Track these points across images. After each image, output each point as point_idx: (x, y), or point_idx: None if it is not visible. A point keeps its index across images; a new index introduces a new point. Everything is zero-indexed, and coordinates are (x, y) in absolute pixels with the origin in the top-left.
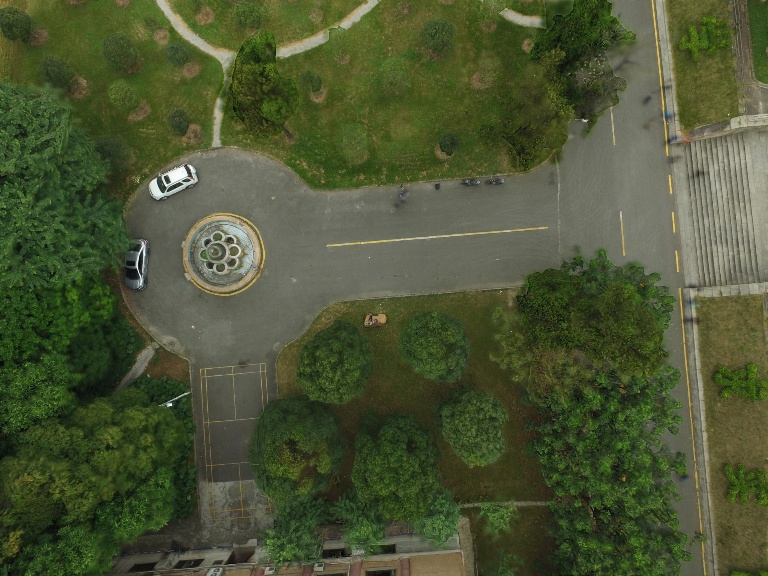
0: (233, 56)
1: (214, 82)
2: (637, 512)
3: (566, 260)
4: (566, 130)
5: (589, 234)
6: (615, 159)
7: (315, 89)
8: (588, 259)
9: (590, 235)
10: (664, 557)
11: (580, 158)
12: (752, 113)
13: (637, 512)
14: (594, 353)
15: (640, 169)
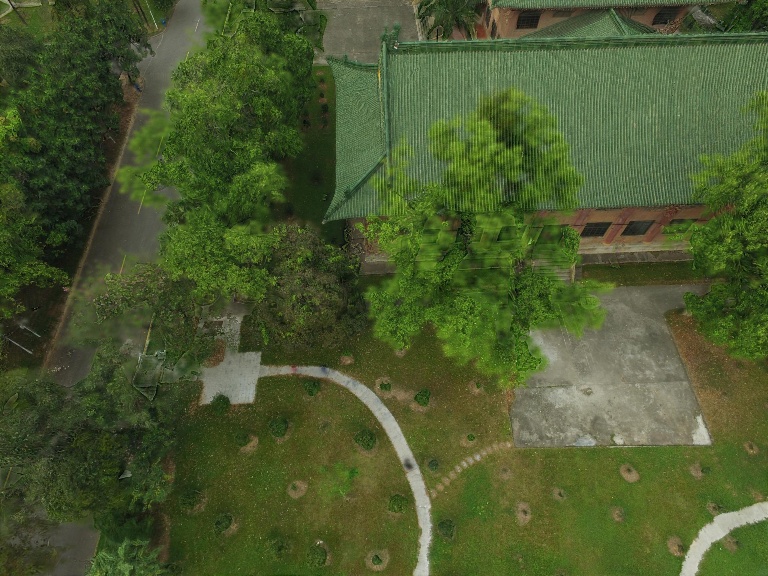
0: (18, 4)
1: (1, 11)
2: (55, 54)
3: (151, 68)
4: (172, 27)
5: (168, 59)
6: (193, 36)
7: (42, 2)
8: (163, 68)
9: (168, 60)
10: (64, 76)
11: (175, 35)
12: (250, 8)
13: (55, 54)
14: (70, 11)
15: (205, 39)
